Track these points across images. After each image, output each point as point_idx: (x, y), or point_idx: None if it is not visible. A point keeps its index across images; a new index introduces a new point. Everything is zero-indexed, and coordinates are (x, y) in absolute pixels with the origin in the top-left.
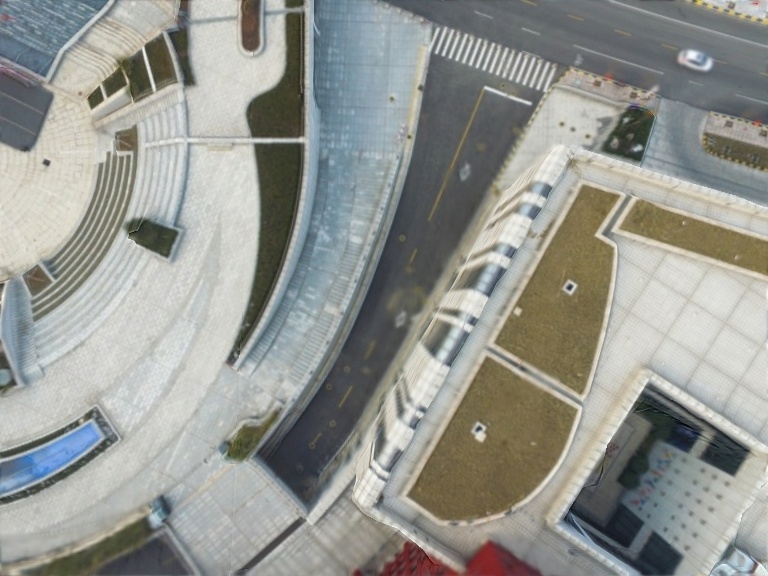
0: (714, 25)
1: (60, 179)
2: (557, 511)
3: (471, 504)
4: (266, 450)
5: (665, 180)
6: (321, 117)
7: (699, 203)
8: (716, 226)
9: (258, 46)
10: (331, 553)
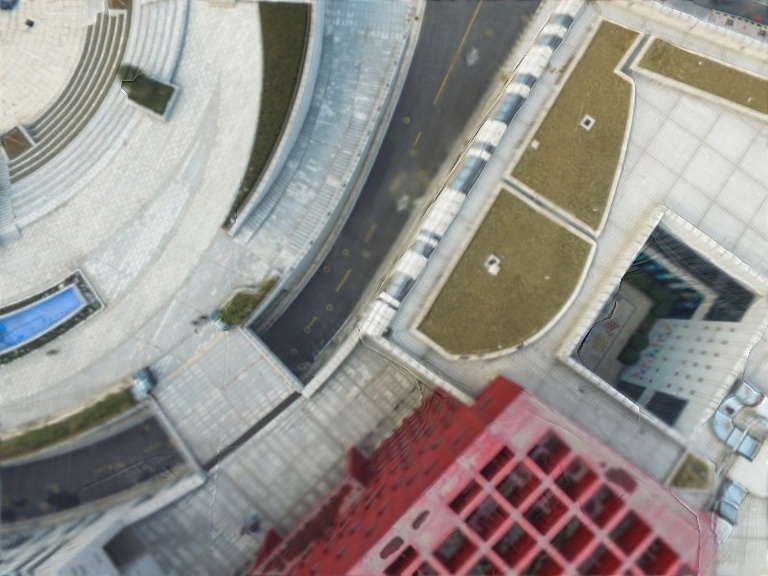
0: None
1: (44, 41)
2: (570, 344)
3: (483, 338)
4: (261, 323)
5: (684, 17)
6: None
7: (714, 47)
8: (731, 68)
9: None
10: (326, 429)
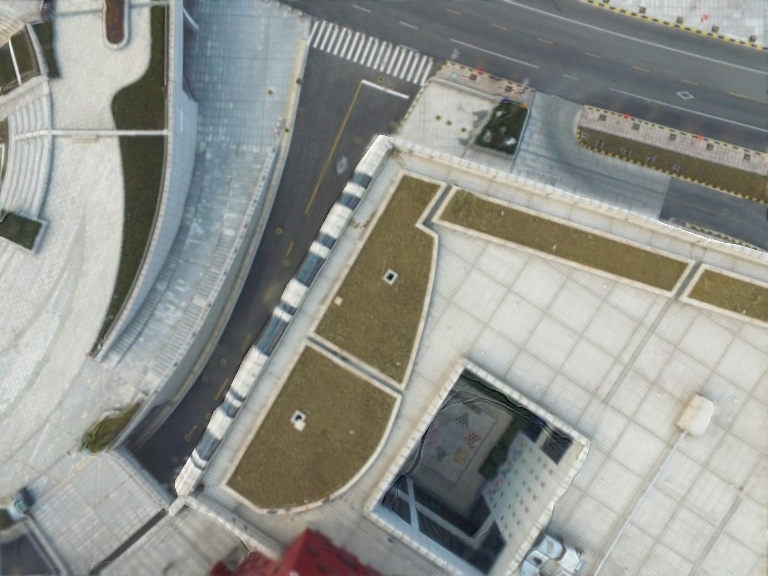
0: (589, 19)
1: None
2: (372, 499)
3: (289, 492)
4: (131, 442)
5: (482, 170)
6: (198, 110)
7: (521, 193)
8: (535, 216)
9: (122, 39)
10: (194, 544)
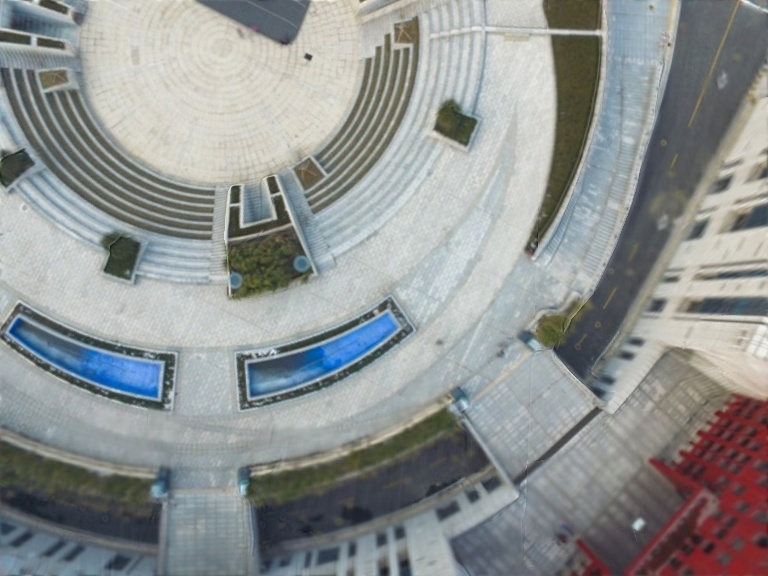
0: None
1: (322, 74)
2: None
3: None
4: (558, 342)
5: None
6: None
7: None
8: None
9: None
10: (625, 443)
